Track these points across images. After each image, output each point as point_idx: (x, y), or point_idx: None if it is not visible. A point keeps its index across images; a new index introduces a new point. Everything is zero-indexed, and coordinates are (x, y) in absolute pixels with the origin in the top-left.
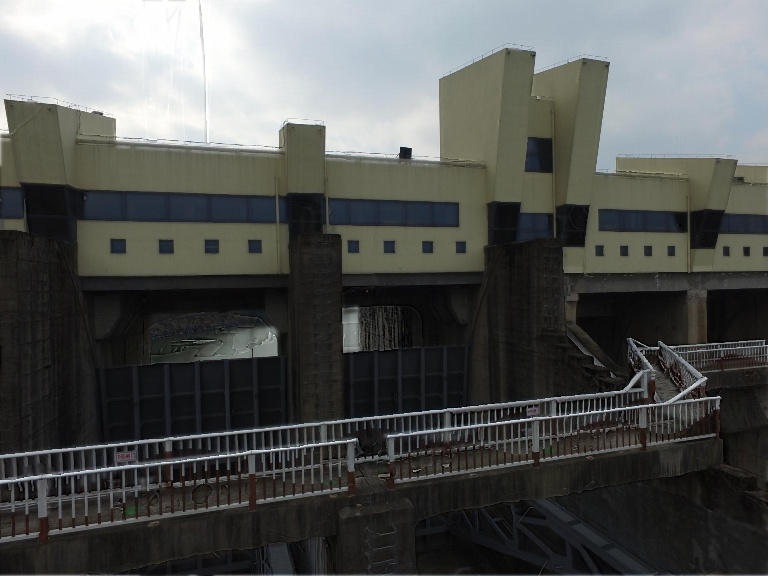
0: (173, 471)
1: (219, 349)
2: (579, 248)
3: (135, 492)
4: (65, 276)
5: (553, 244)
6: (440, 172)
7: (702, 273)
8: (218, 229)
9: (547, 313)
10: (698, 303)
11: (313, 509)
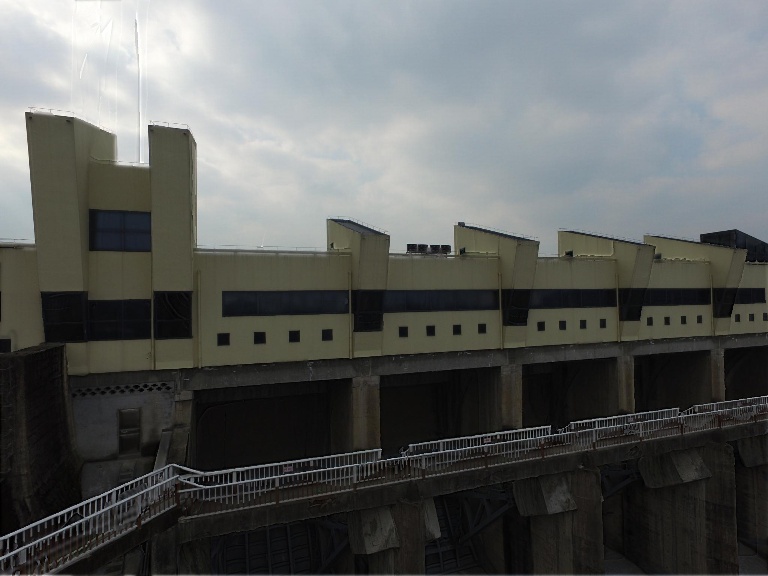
0: None
1: None
2: (183, 340)
3: None
4: None
5: (4, 365)
6: None
7: (372, 357)
8: None
9: None
10: (367, 391)
11: None
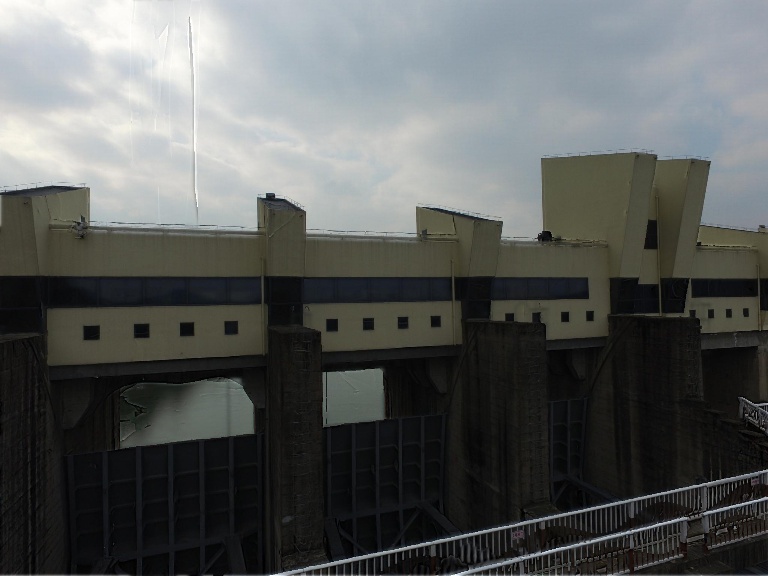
0: (588, 550)
1: None
2: (680, 314)
3: (568, 567)
4: None
5: (694, 324)
6: (574, 252)
7: None
8: (408, 307)
9: (690, 381)
10: (766, 356)
11: (666, 573)
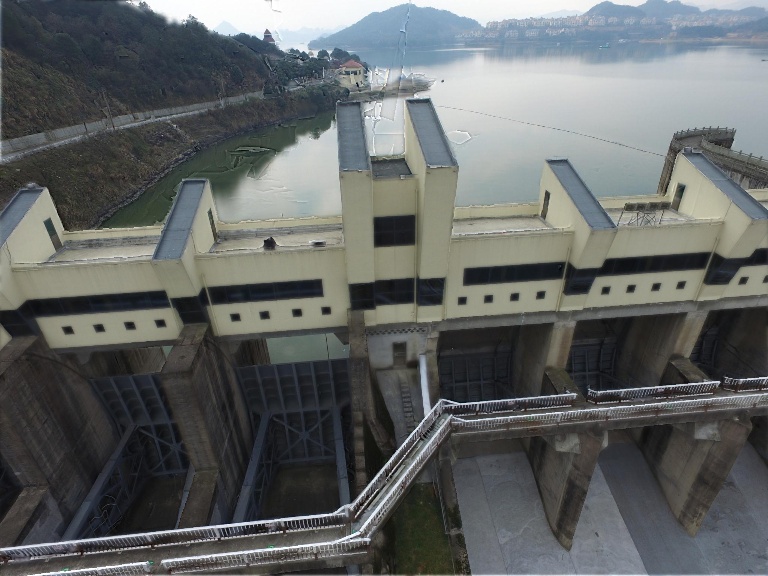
0: (67, 575)
1: (282, 143)
2: (436, 306)
3: None
4: (39, 364)
5: (359, 362)
6: (302, 258)
7: None
8: (131, 315)
9: (357, 401)
10: (564, 331)
11: None
